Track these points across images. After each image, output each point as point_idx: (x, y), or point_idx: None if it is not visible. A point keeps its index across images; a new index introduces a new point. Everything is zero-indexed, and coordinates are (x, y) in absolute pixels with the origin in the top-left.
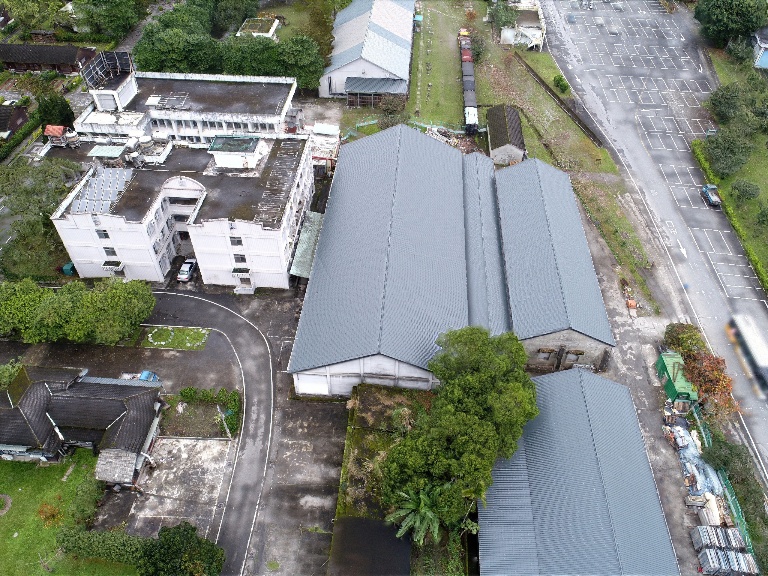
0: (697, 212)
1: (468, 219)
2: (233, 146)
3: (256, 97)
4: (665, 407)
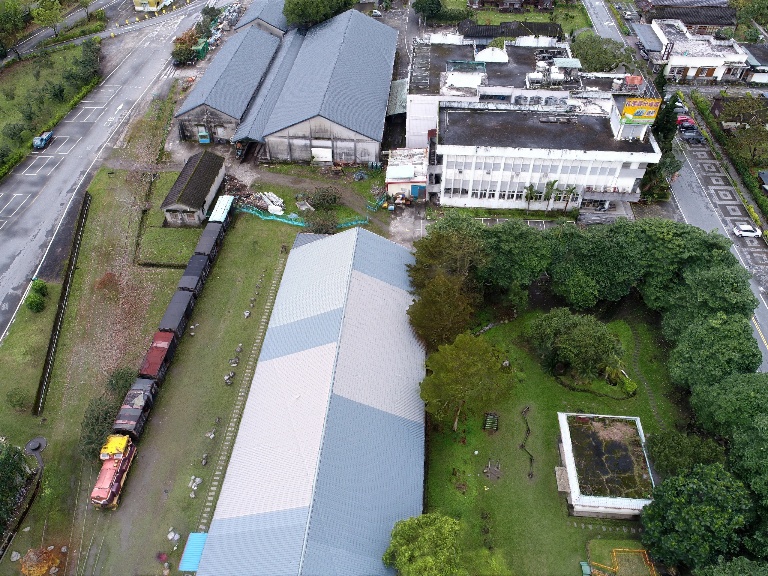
0: (72, 133)
1: (280, 92)
2: (467, 67)
3: (477, 133)
4: (212, 49)
